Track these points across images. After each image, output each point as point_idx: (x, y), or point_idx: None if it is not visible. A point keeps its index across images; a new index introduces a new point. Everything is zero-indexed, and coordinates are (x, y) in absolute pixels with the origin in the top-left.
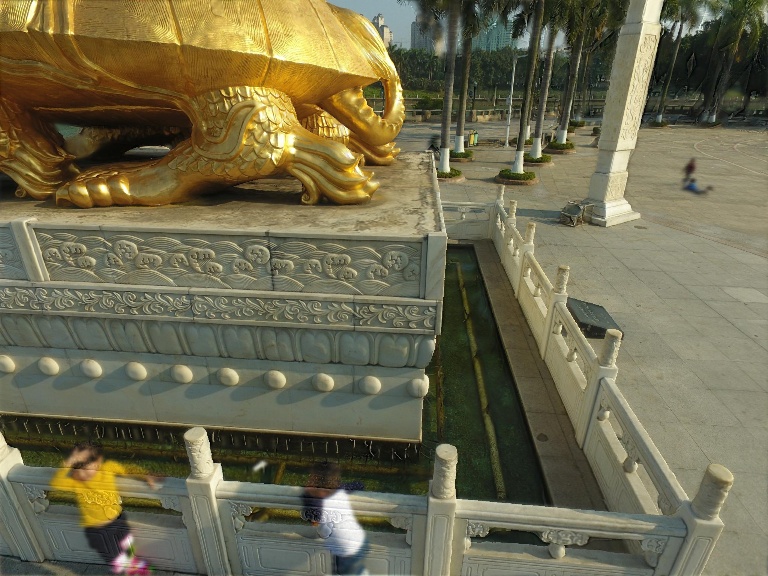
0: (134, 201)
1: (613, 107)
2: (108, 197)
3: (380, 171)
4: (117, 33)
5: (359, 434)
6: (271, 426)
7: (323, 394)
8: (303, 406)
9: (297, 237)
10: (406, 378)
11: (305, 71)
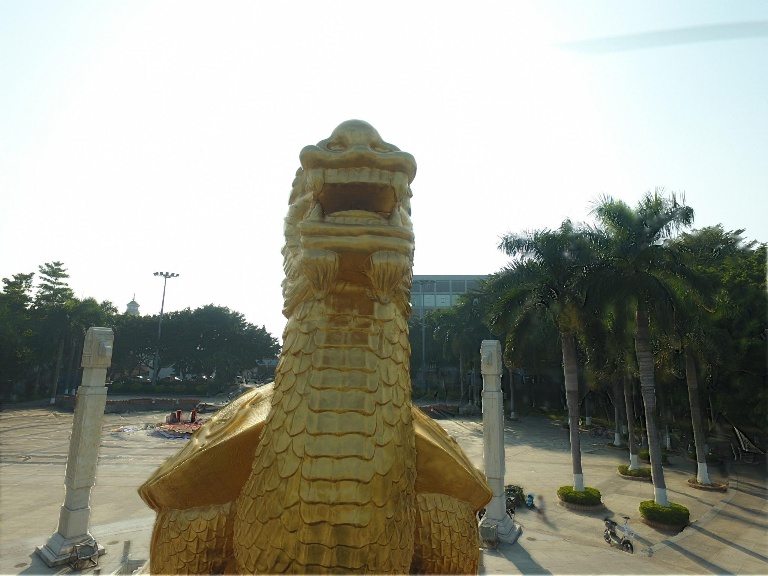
0: None
1: (89, 450)
2: None
3: None
4: None
5: None
6: None
7: None
8: None
9: None
10: None
11: None
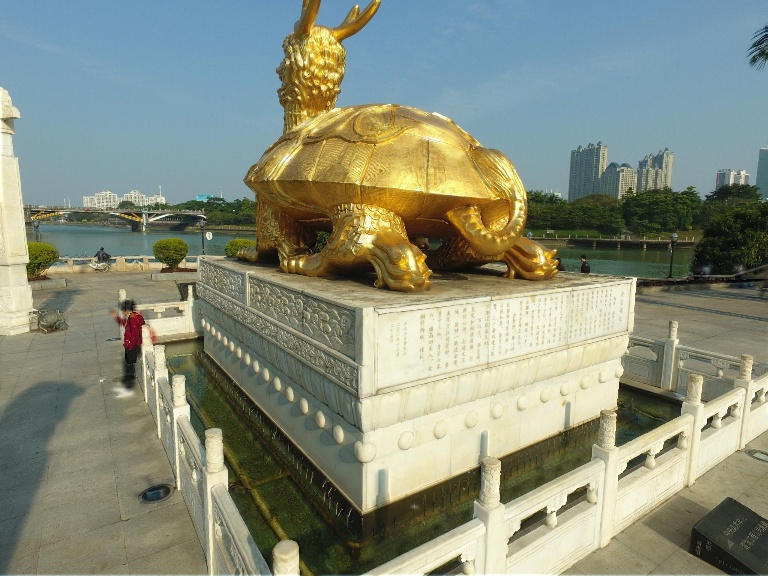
0: (303, 272)
1: None
2: (294, 268)
3: (511, 282)
4: (289, 177)
5: (335, 481)
6: (302, 446)
7: (320, 430)
8: (314, 436)
9: (311, 296)
10: (355, 437)
11: (390, 193)
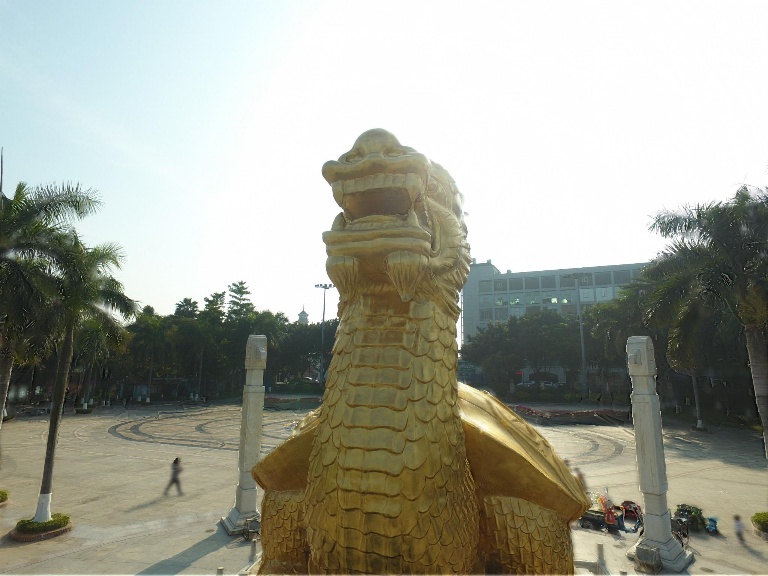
0: None
1: (253, 439)
2: None
3: None
4: None
5: None
6: None
7: None
8: None
9: None
10: None
11: None
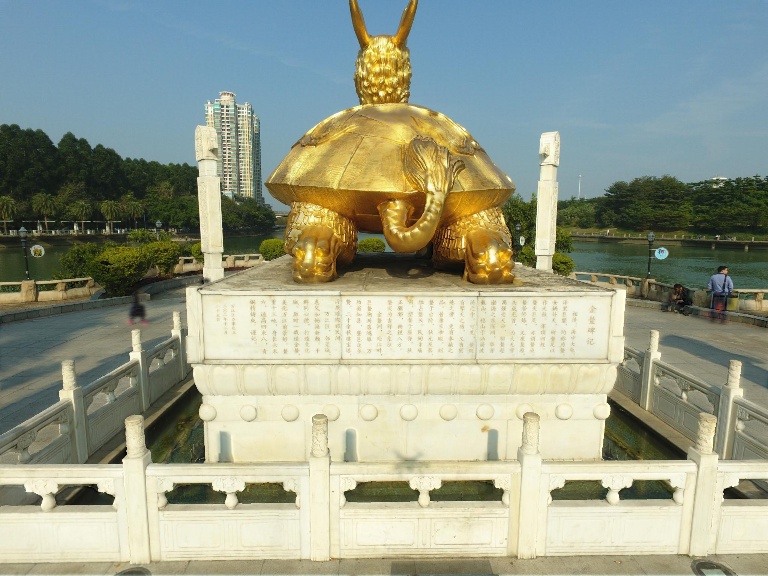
0: None
1: None
2: None
3: (441, 283)
4: None
5: None
6: None
7: None
8: None
9: None
10: None
11: None
